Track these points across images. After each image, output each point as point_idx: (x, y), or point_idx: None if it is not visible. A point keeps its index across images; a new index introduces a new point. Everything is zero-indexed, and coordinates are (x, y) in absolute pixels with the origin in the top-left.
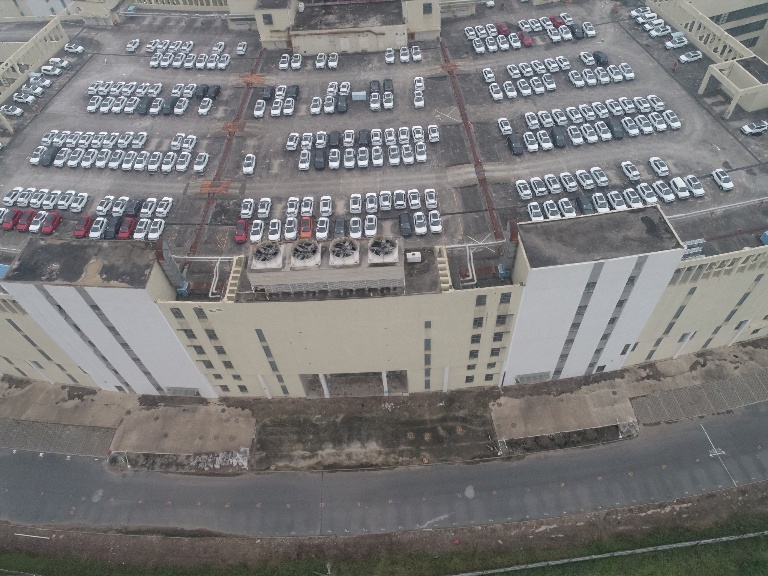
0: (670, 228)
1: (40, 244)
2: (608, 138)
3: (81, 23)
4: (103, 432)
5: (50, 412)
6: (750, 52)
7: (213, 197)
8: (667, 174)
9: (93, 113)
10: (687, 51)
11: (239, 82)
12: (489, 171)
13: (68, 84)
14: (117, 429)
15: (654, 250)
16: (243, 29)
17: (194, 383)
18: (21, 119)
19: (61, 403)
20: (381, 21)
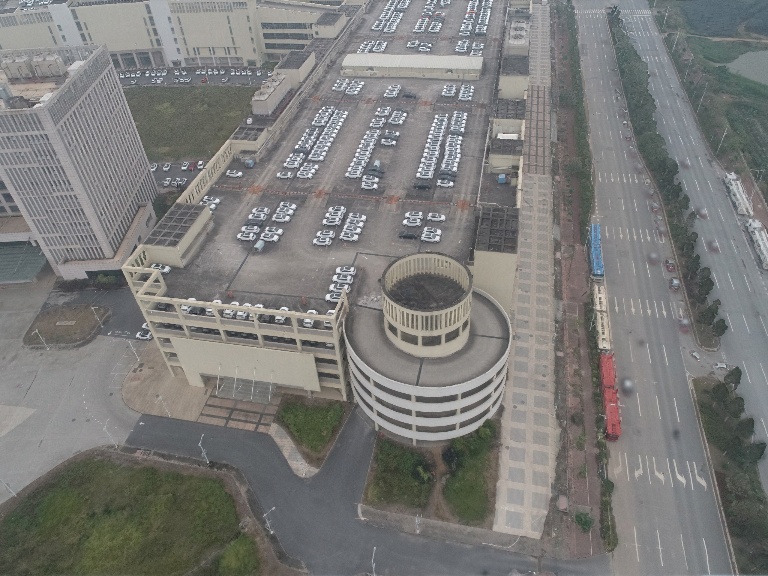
0: None
1: None
2: None
3: None
4: None
5: None
6: None
7: None
8: None
9: None
10: None
11: None
12: None
13: None
14: None
15: None
16: None
17: None
18: None
19: None
20: None
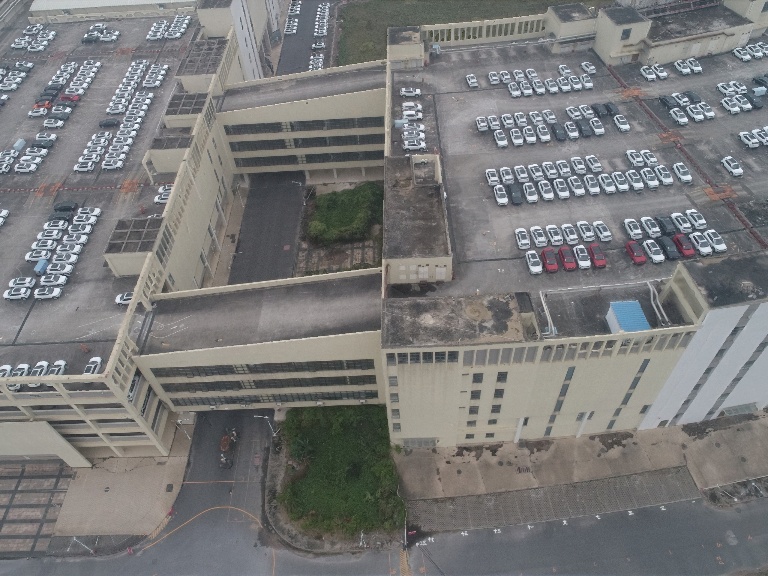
0: None
1: (700, 266)
2: None
3: (383, 69)
4: (675, 472)
5: (600, 467)
6: None
7: (730, 202)
8: None
9: (505, 148)
10: None
11: (622, 97)
12: None
13: (440, 126)
14: (688, 466)
15: None
16: (566, 51)
17: (760, 396)
18: (429, 166)
19: (603, 455)
20: (726, 23)
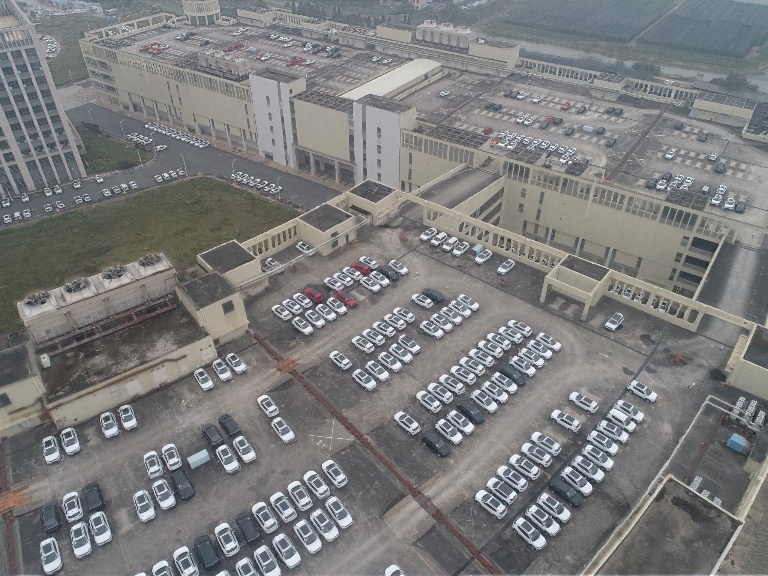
0: (708, 502)
1: None
2: (516, 390)
3: None
4: None
5: None
6: (562, 252)
7: None
8: (597, 408)
9: None
10: (496, 261)
11: None
12: (435, 496)
13: None
14: None
15: (723, 543)
16: None
17: None
18: None
19: None
20: (174, 341)
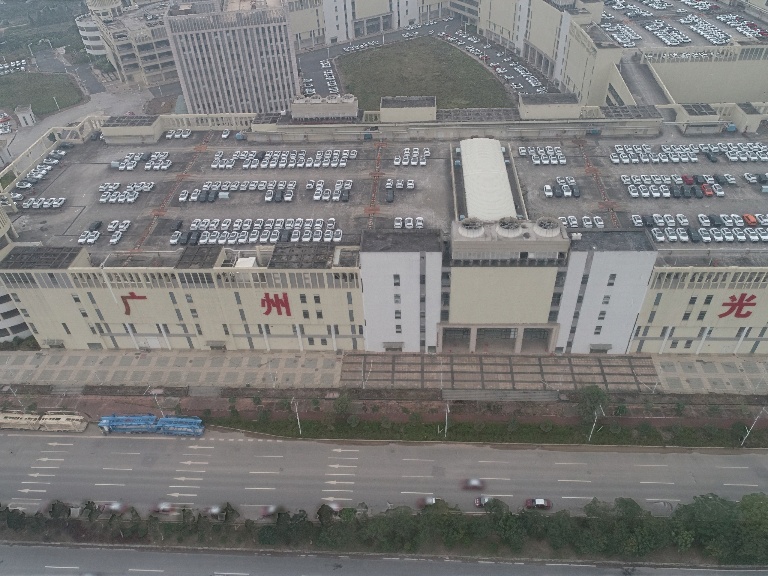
0: None
1: None
2: None
3: (619, 66)
4: None
5: None
6: None
7: None
8: None
9: None
10: None
11: None
12: None
13: None
14: None
15: None
16: None
17: None
18: None
19: None
20: None
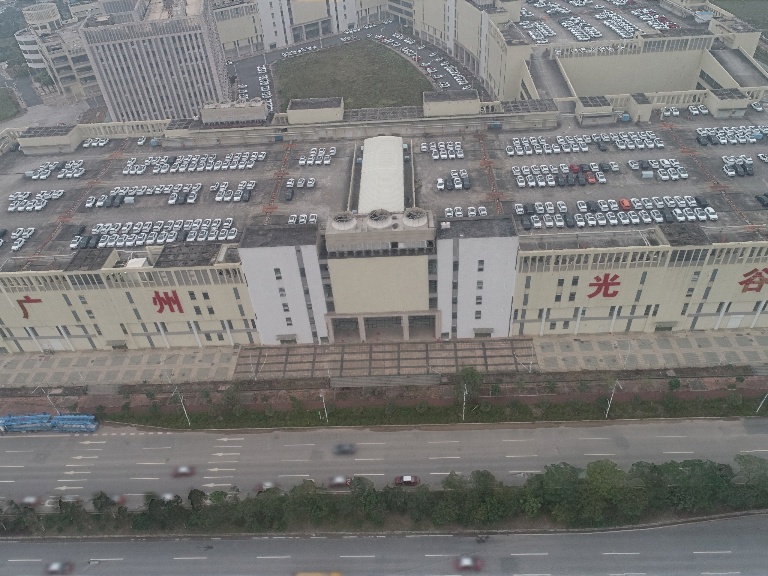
0: None
1: None
2: None
3: (529, 62)
4: None
5: None
6: None
7: None
8: None
9: None
10: None
11: None
12: None
13: None
14: None
15: None
16: None
17: None
18: None
19: None
20: None
